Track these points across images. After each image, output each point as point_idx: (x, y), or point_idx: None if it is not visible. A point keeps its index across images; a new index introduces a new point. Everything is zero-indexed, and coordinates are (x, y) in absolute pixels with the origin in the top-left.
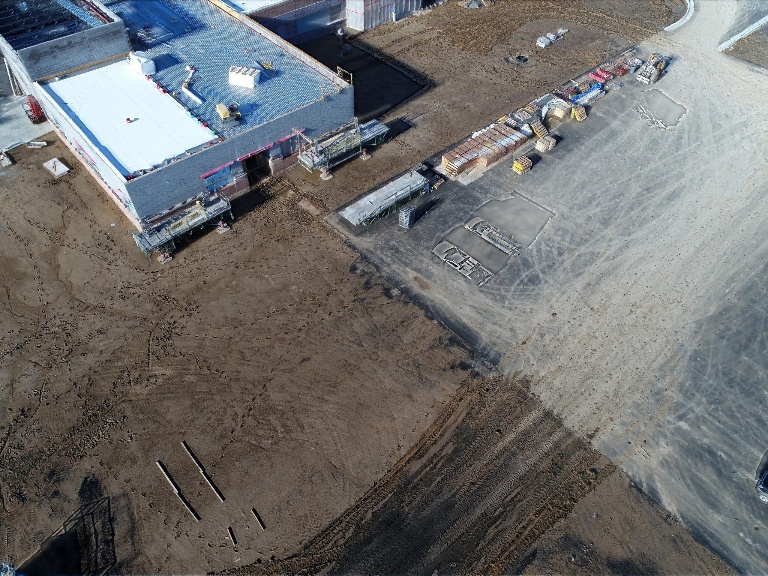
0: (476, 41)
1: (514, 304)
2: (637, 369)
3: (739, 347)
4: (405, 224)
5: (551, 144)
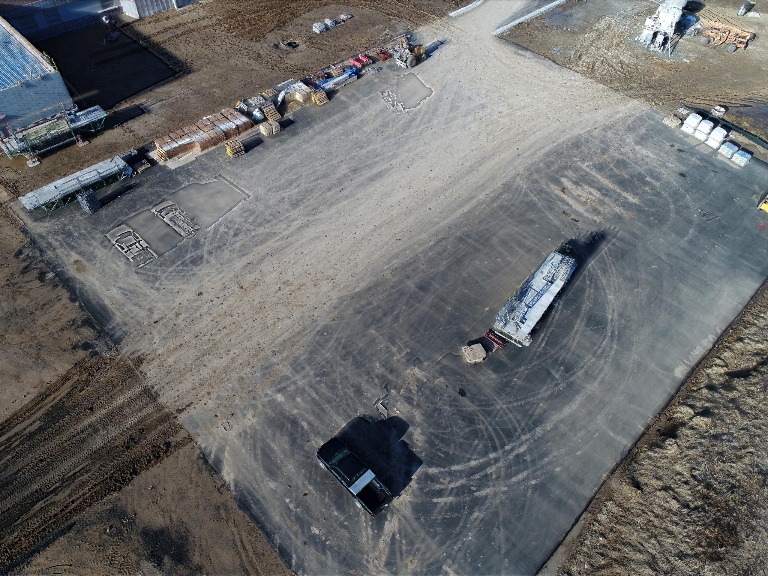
0: (253, 28)
1: (164, 285)
2: (258, 345)
3: (372, 321)
4: (87, 209)
5: (274, 128)
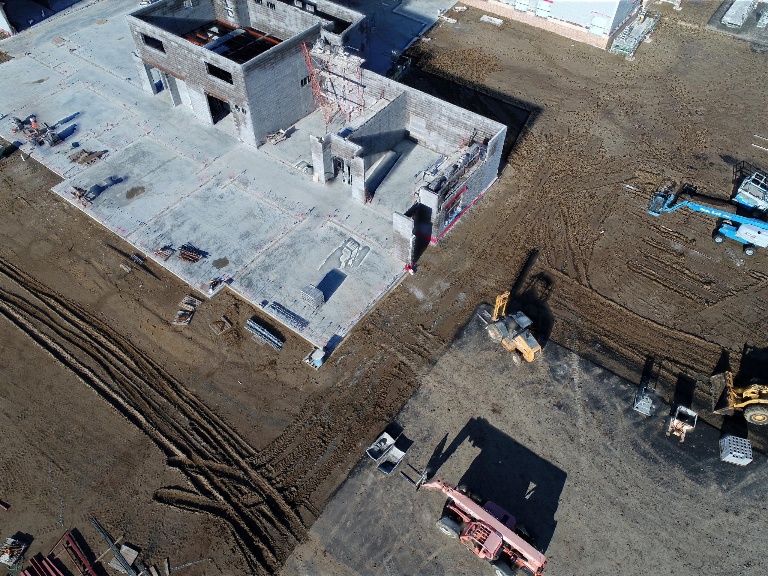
0: None
1: None
2: None
3: None
4: (763, 24)
5: None
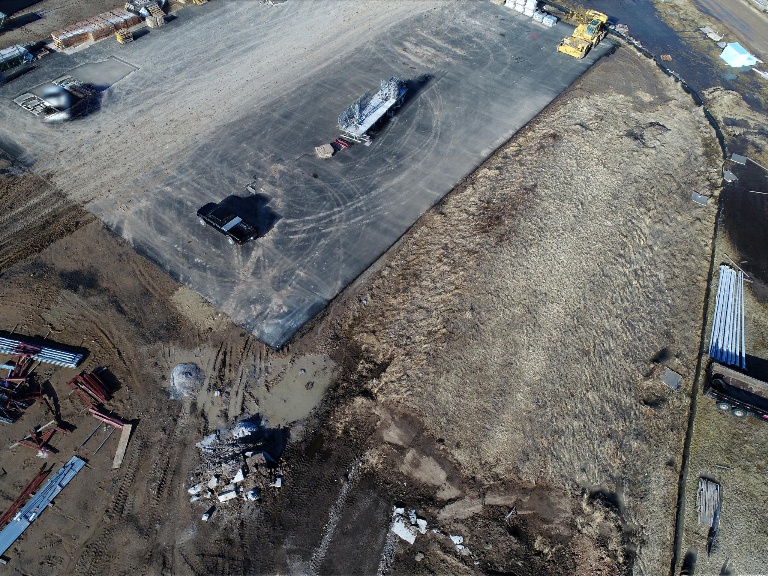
0: None
1: (67, 128)
2: (149, 159)
3: (243, 139)
4: None
5: (158, 20)
